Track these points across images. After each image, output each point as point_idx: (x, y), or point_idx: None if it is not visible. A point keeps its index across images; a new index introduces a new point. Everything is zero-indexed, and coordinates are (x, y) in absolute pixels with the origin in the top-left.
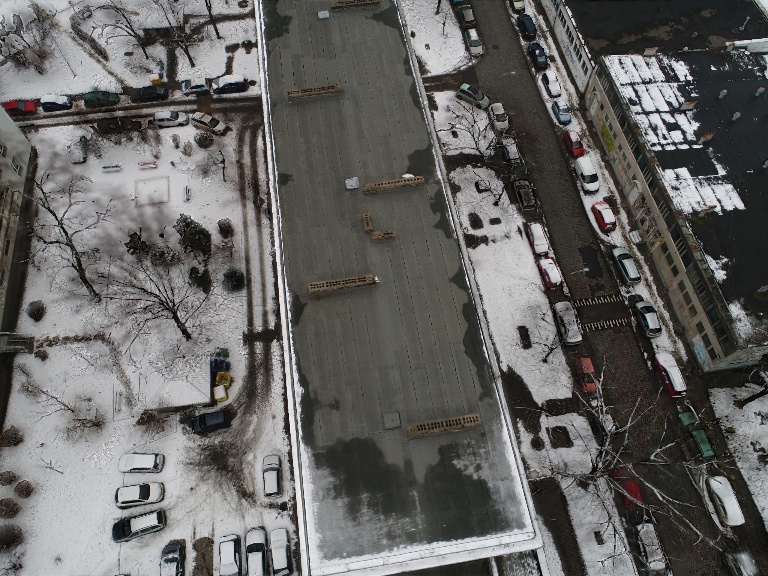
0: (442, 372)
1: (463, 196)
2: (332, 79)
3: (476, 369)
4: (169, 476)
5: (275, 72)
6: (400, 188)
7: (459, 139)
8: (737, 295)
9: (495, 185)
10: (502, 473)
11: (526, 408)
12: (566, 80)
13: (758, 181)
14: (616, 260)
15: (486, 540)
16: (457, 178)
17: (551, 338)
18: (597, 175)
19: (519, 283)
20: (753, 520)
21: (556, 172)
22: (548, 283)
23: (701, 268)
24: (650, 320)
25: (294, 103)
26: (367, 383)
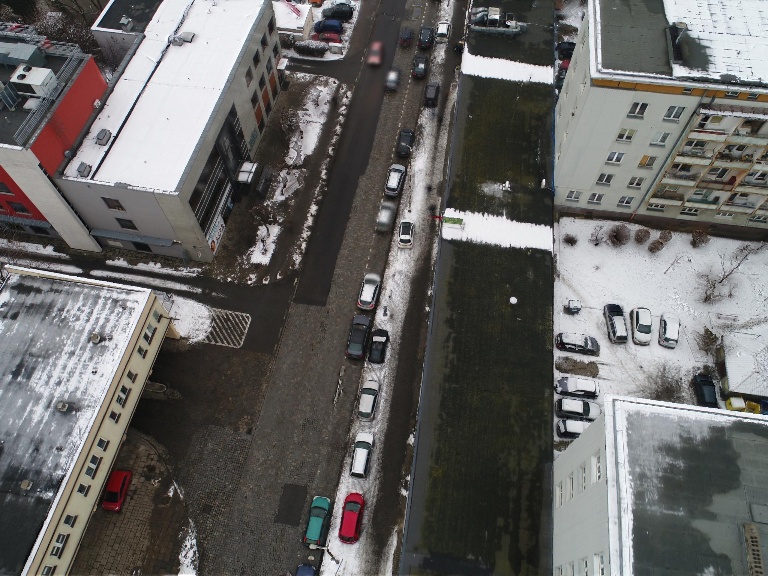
0: None
1: None
2: None
3: None
4: (655, 351)
5: None
6: None
7: None
8: None
9: None
10: None
11: None
12: None
13: None
14: None
15: (630, 571)
16: None
17: None
18: None
19: None
20: None
21: None
22: None
23: None
24: None
25: None
26: None
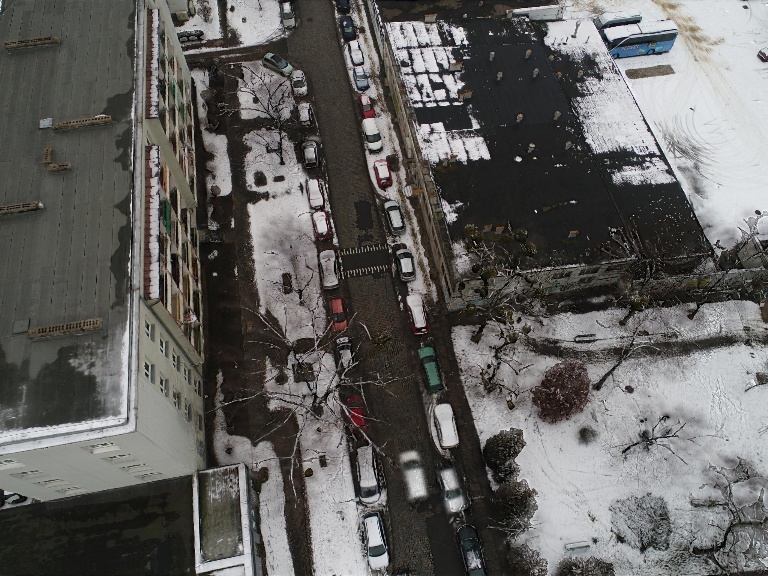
0: (82, 285)
1: (252, 156)
2: (55, 32)
3: (116, 282)
4: None
5: (4, 27)
6: (89, 127)
7: (259, 104)
8: (463, 235)
9: (285, 146)
10: (113, 369)
11: (256, 342)
12: (372, 50)
13: (509, 134)
14: (385, 212)
15: (78, 425)
16: (250, 140)
17: (312, 284)
18: (384, 136)
19: (291, 234)
20: (471, 442)
21: (346, 134)
22: (316, 233)
23: (434, 211)
24: (404, 265)
25: (13, 54)
26: (9, 295)
